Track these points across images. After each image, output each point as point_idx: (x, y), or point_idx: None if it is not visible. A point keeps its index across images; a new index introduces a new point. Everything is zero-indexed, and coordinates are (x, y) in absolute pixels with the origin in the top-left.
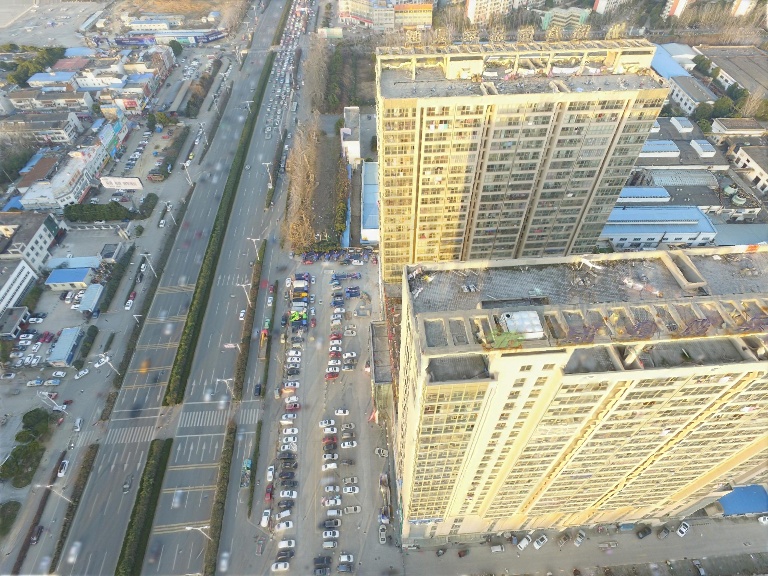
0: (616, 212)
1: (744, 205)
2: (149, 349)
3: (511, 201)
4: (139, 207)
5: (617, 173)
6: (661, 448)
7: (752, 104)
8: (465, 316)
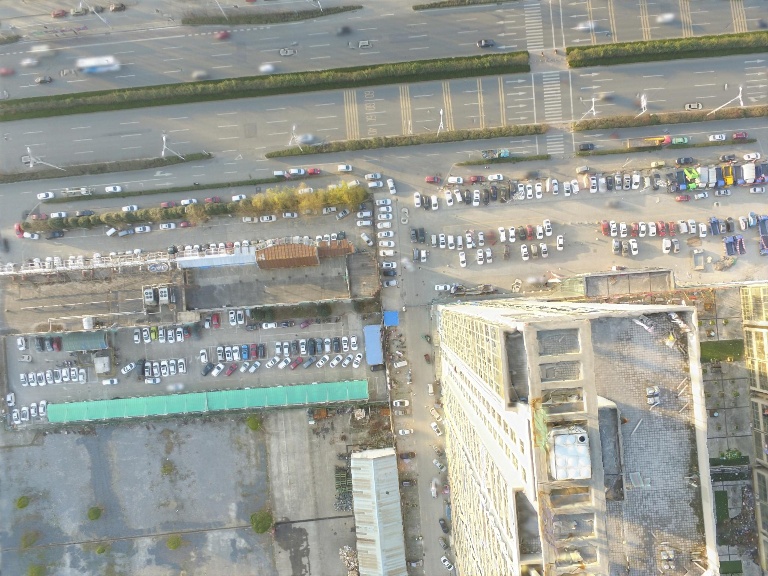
0: None
1: None
2: (640, 7)
3: None
4: None
5: None
6: (481, 572)
7: None
8: (585, 383)
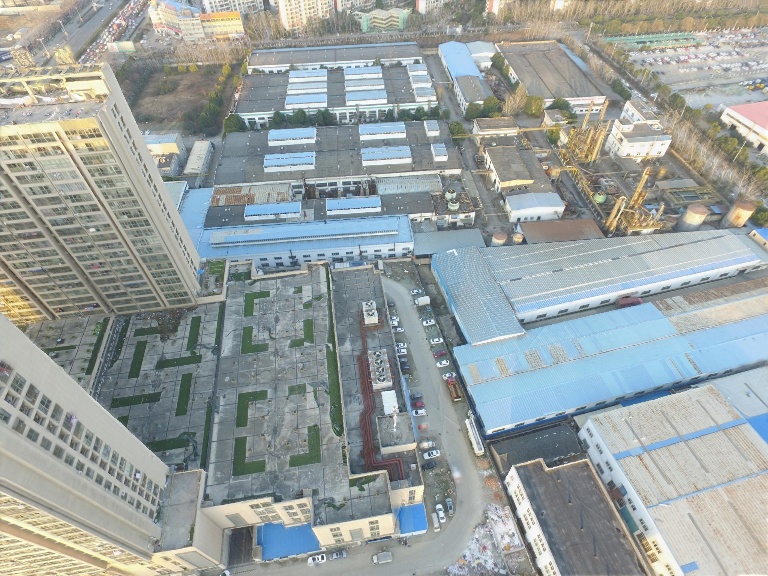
0: (315, 227)
1: (459, 210)
2: None
3: (28, 240)
4: None
5: (125, 205)
6: None
7: (509, 103)
8: None
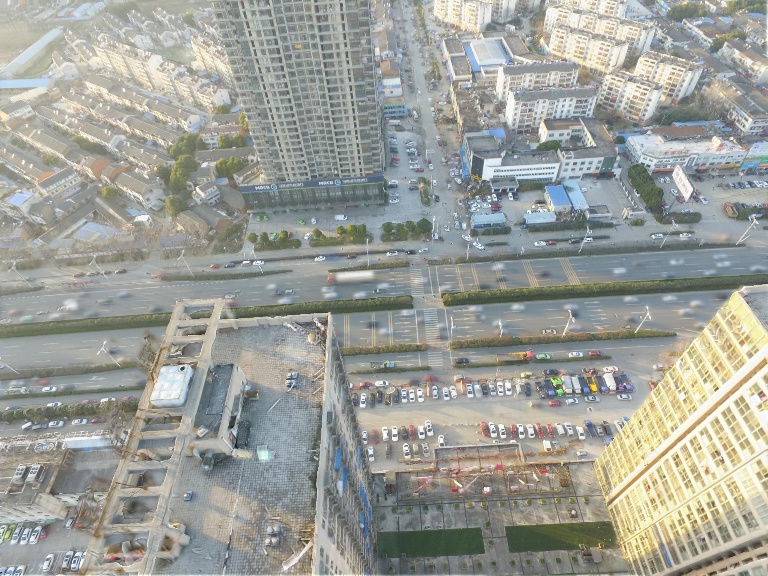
0: None
1: None
2: (496, 271)
3: None
4: (673, 212)
5: None
6: None
7: None
8: (206, 336)
